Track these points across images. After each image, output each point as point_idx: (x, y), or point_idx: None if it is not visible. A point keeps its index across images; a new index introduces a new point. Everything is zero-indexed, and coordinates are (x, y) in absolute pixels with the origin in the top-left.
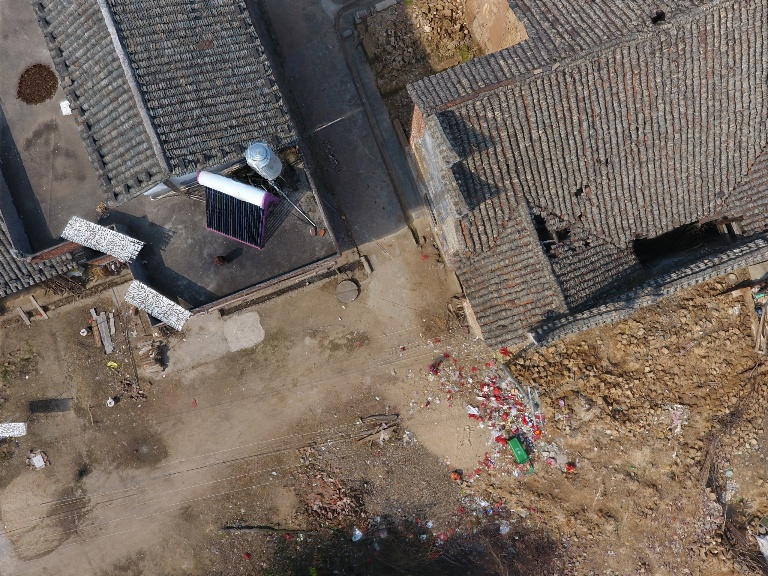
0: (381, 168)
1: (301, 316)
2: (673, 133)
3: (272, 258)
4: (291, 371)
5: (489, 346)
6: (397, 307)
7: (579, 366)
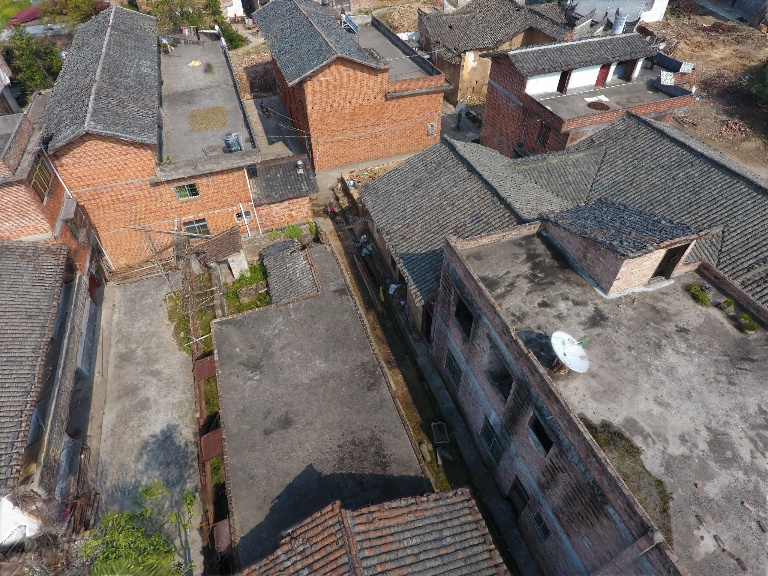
0: None
1: None
2: None
3: None
4: None
5: None
6: None
7: None
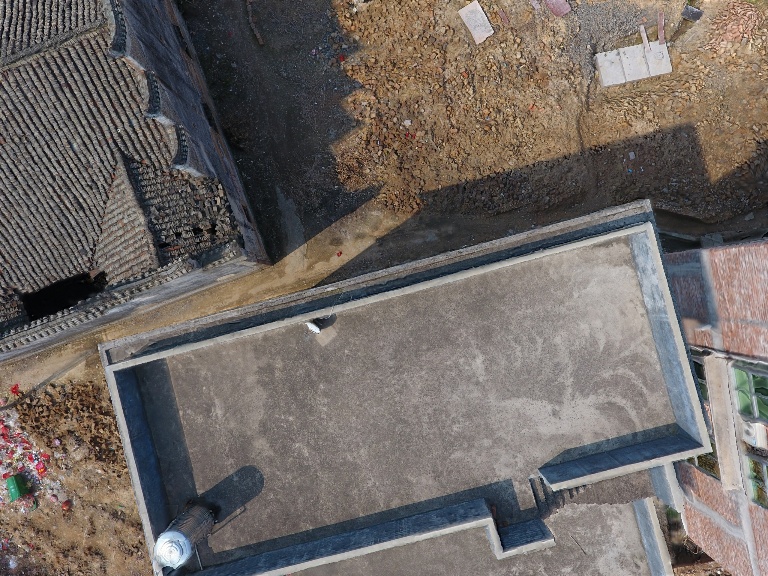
0: None
1: None
2: None
3: None
4: None
5: None
6: None
7: (78, 406)
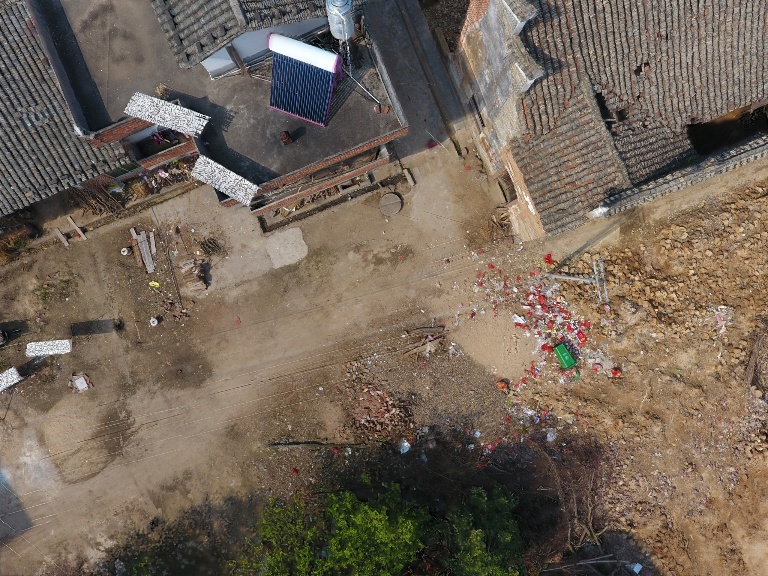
0: (422, 80)
1: (344, 231)
2: (732, 7)
3: (336, 136)
4: (335, 286)
5: (548, 232)
6: (440, 219)
7: (624, 272)
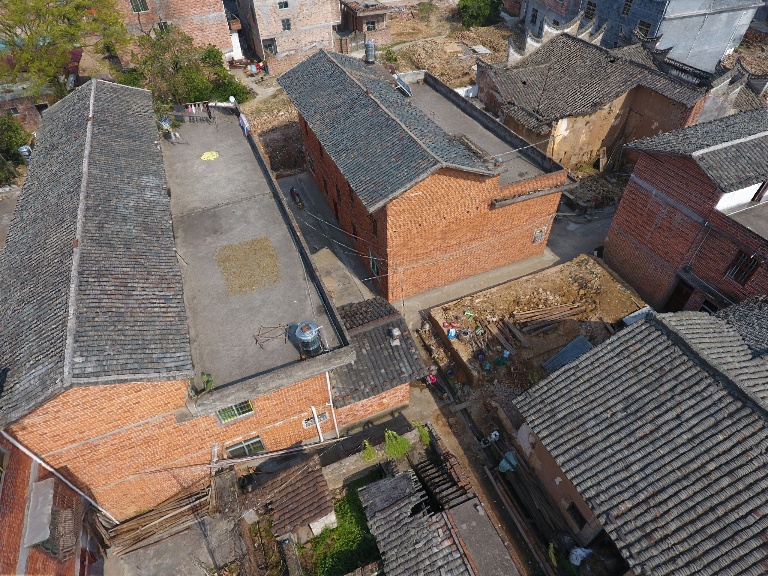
0: None
1: None
2: None
3: None
4: None
5: None
6: None
7: None
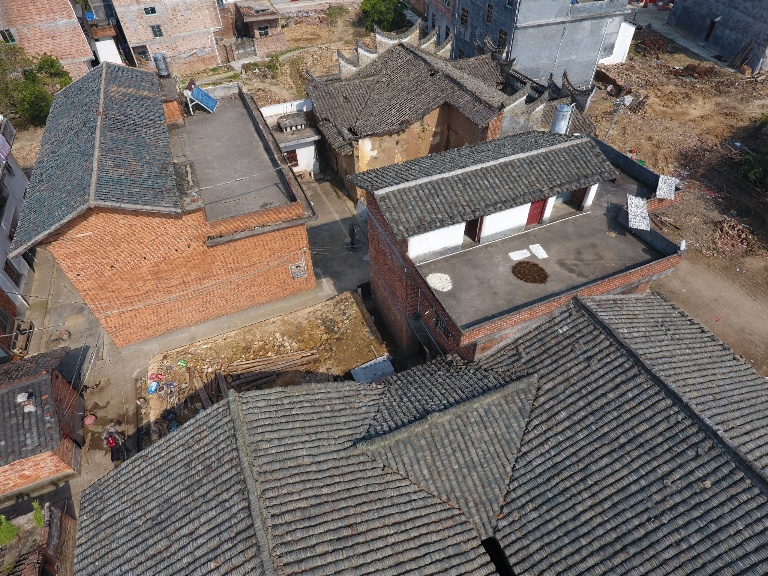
0: None
1: None
2: None
3: None
4: None
5: None
6: None
7: None
